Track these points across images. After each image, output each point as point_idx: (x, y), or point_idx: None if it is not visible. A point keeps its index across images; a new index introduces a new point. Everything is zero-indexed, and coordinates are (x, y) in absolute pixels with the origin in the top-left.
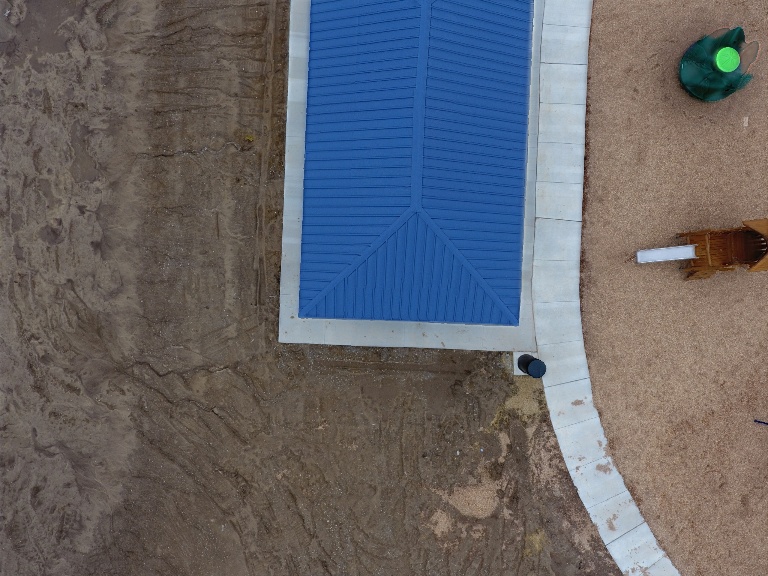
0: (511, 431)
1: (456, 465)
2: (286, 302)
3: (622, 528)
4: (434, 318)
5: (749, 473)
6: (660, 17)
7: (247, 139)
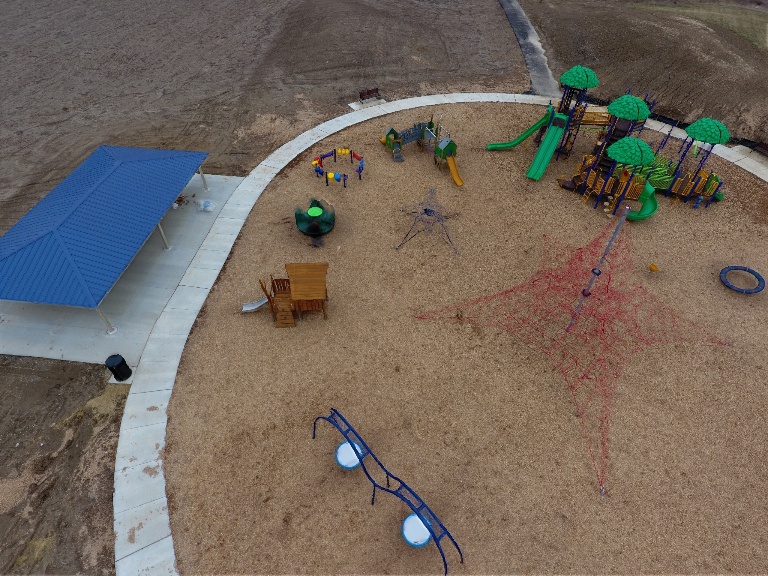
0: (79, 429)
1: (7, 456)
2: None
3: (143, 541)
4: (37, 300)
5: (299, 489)
6: (296, 204)
7: None
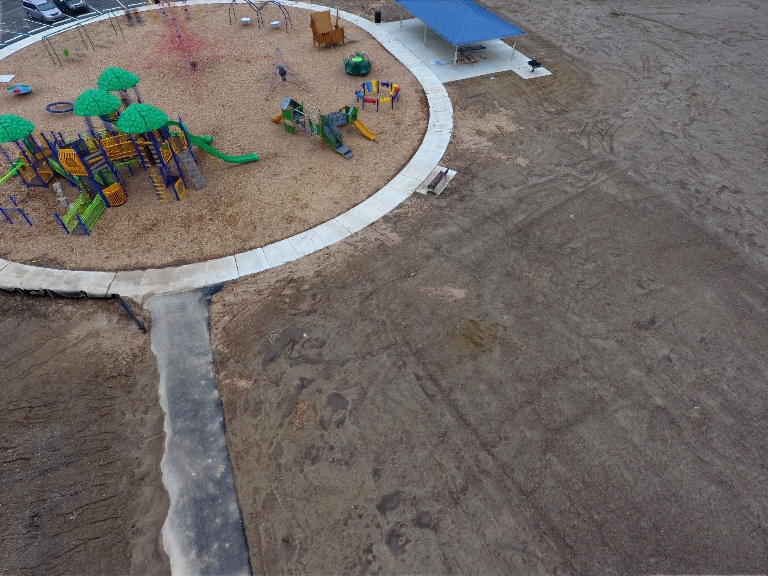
0: (373, 14)
1: (386, 8)
2: None
3: None
4: None
5: None
6: None
7: None
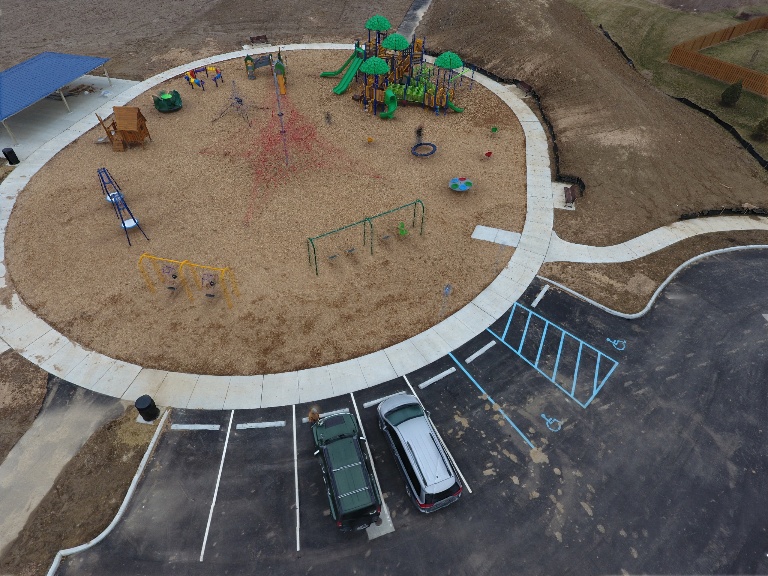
0: None
1: None
2: None
3: None
4: None
5: None
6: None
7: None
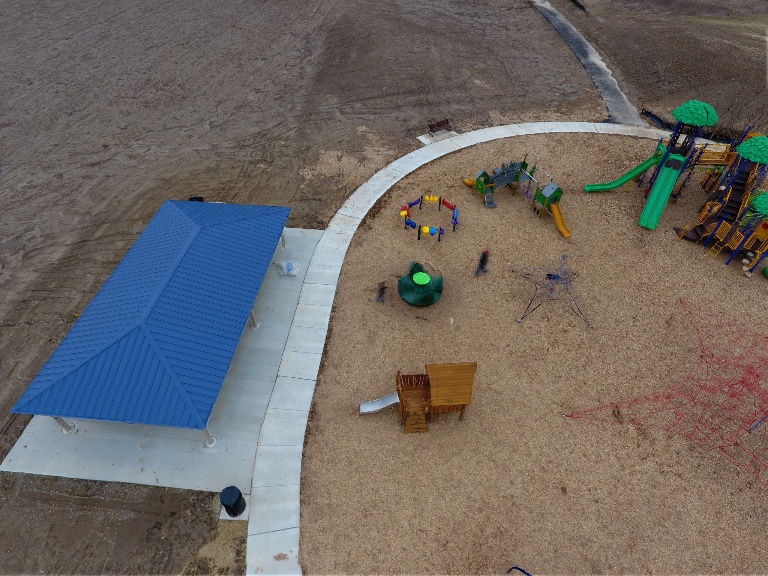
0: None
1: None
2: (28, 432)
3: None
4: (130, 418)
5: None
6: (389, 264)
7: (74, 315)
